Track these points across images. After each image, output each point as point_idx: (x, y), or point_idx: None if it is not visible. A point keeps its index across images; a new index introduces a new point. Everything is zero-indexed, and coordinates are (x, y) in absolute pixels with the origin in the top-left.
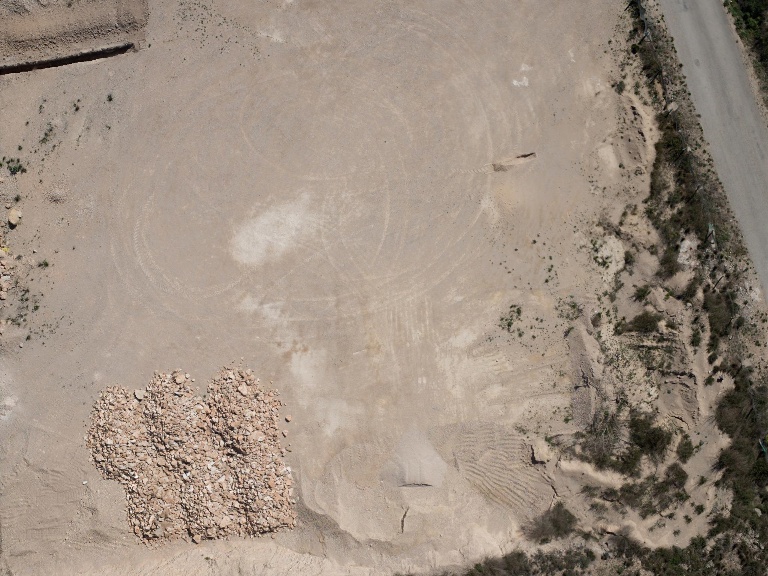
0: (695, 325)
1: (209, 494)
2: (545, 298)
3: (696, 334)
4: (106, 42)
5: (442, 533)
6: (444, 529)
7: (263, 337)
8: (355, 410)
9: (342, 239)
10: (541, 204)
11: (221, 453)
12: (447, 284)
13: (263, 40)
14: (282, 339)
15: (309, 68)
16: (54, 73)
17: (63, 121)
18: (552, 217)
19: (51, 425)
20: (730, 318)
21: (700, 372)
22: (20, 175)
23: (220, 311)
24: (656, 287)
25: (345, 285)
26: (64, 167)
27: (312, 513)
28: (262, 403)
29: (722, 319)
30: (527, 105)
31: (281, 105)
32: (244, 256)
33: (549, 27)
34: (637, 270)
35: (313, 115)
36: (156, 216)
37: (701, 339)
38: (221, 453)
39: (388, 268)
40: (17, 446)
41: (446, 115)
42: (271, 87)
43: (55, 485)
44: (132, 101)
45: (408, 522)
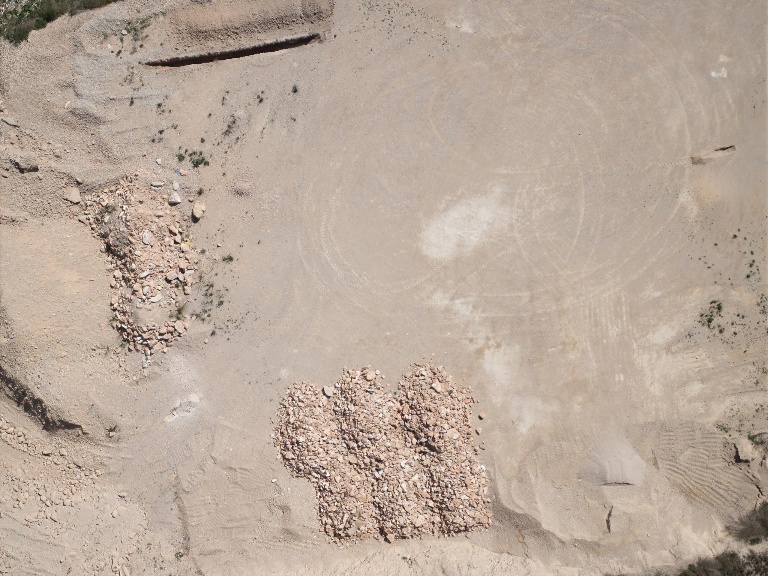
0: None
1: (404, 493)
2: (747, 294)
3: None
4: (290, 32)
5: (649, 533)
6: (650, 529)
7: (454, 333)
8: (550, 407)
9: (536, 233)
10: (741, 198)
11: (413, 451)
12: (644, 279)
13: (452, 30)
14: (474, 335)
15: (500, 59)
16: (237, 64)
17: (246, 113)
18: (753, 211)
19: (237, 422)
20: None
21: None
22: (203, 168)
23: (410, 306)
24: None
25: (539, 280)
26: (248, 160)
27: (510, 512)
28: (456, 400)
29: None
30: (726, 97)
31: (471, 97)
32: (434, 251)
33: (748, 17)
34: None
35: (504, 107)
36: (343, 210)
37: None
38: (413, 451)
39: (583, 263)
40: (203, 443)
41: (642, 107)
42: (461, 78)
43: (244, 483)
44: (318, 93)
45: (614, 522)
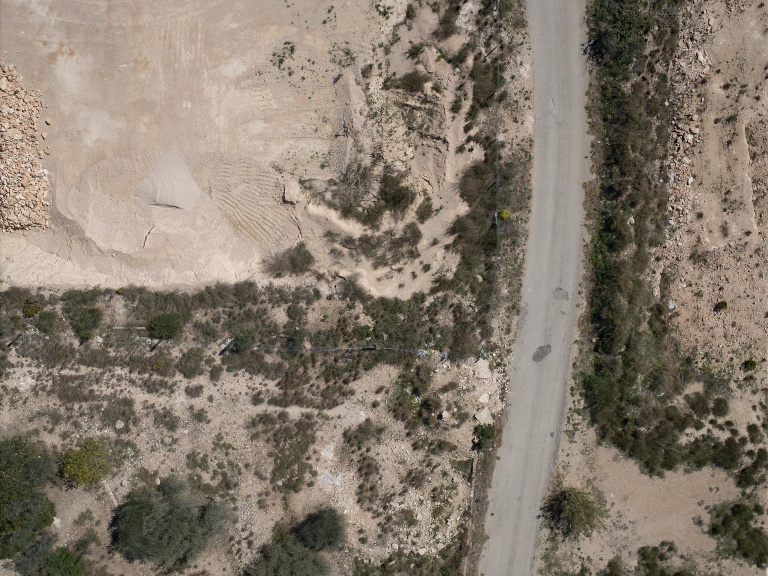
0: (459, 92)
1: None
2: (320, 40)
3: (458, 101)
4: None
5: (183, 254)
6: (185, 251)
7: (29, 33)
8: (117, 123)
9: None
10: None
11: None
12: (224, 8)
13: None
14: (48, 38)
15: None
16: None
17: None
18: None
19: None
20: (493, 90)
21: (454, 139)
22: None
23: None
24: (431, 47)
25: None
26: None
27: (62, 217)
28: (21, 101)
29: (485, 90)
30: None
31: None
32: None
33: None
34: (416, 26)
35: None
36: None
37: (462, 107)
38: None
39: None
40: None
41: None
42: None
43: None
44: None
45: (151, 239)
